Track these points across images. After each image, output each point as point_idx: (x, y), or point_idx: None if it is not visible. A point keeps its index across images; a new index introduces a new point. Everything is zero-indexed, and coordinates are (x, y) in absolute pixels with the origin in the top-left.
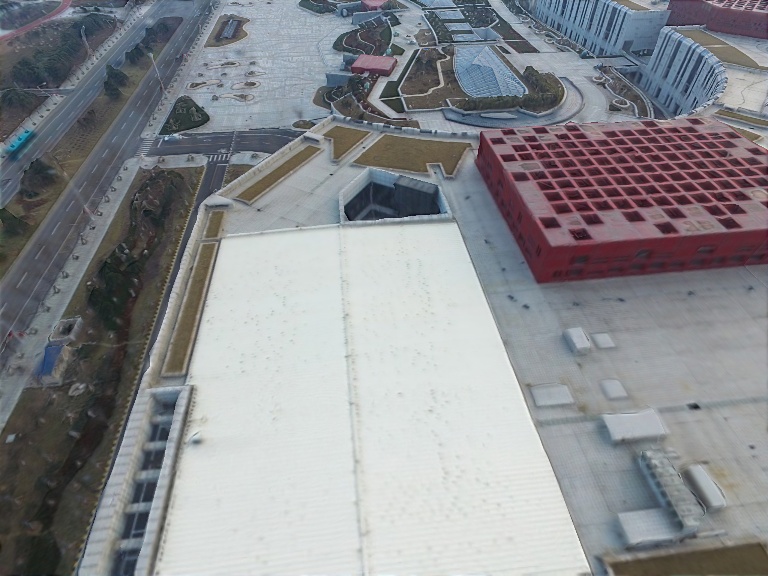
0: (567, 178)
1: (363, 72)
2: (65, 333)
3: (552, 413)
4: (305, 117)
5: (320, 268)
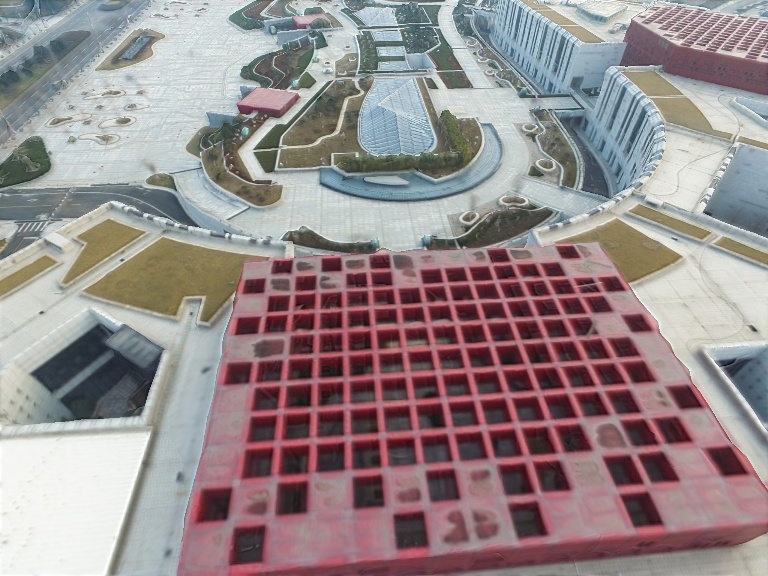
0: (309, 380)
1: (251, 111)
2: None
3: None
4: (167, 169)
5: None
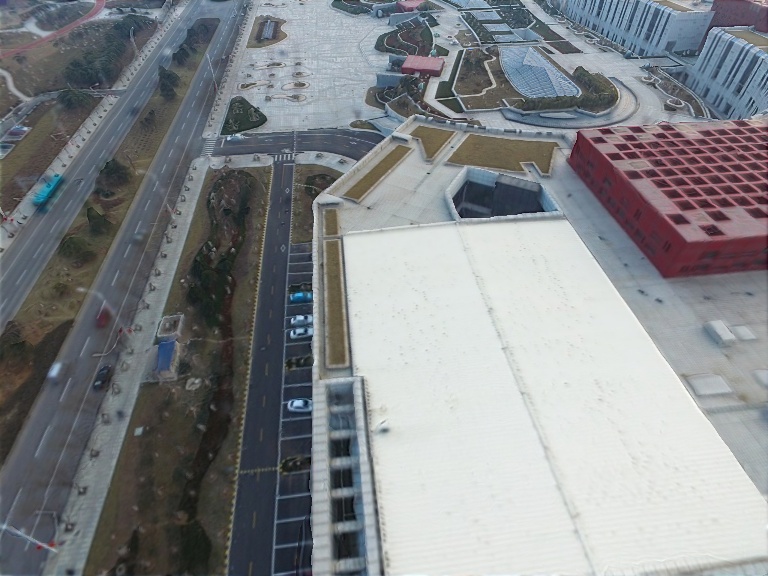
0: (679, 176)
1: (413, 73)
2: (171, 329)
3: (714, 402)
4: (361, 117)
5: (450, 264)
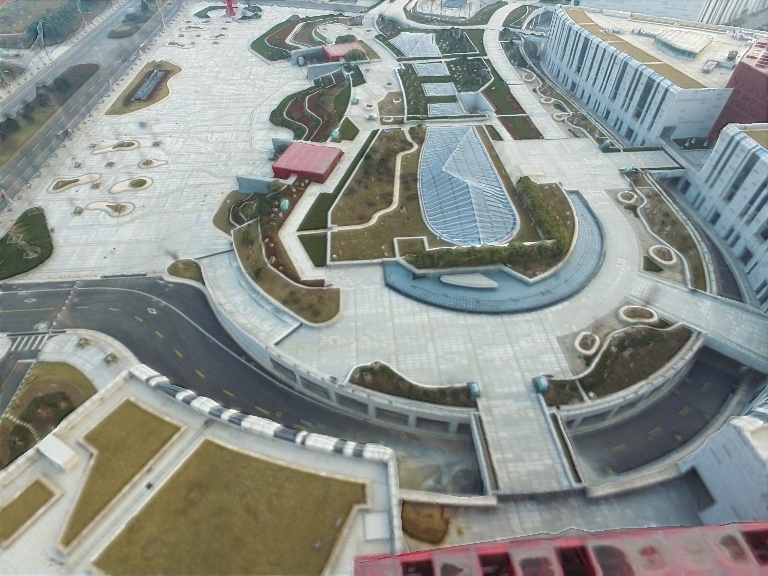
0: None
1: (288, 175)
2: None
3: None
4: (192, 252)
5: None
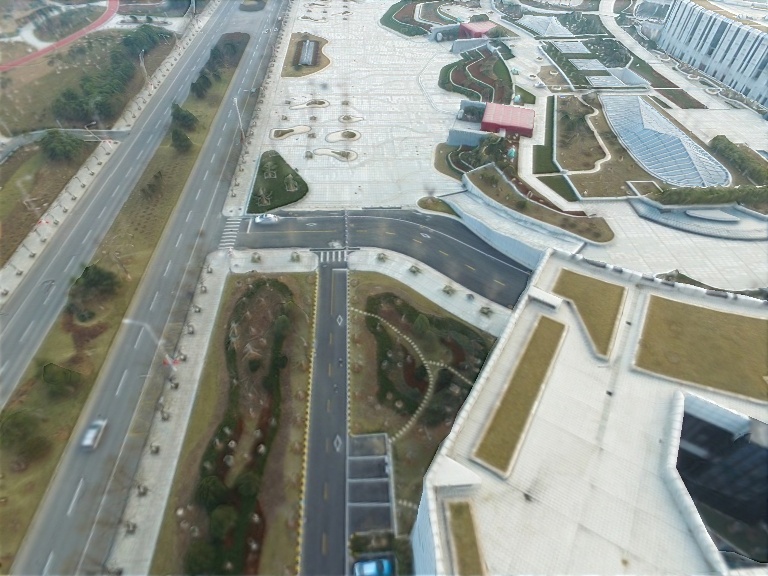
0: None
1: (497, 129)
2: None
3: None
4: (431, 191)
5: None
